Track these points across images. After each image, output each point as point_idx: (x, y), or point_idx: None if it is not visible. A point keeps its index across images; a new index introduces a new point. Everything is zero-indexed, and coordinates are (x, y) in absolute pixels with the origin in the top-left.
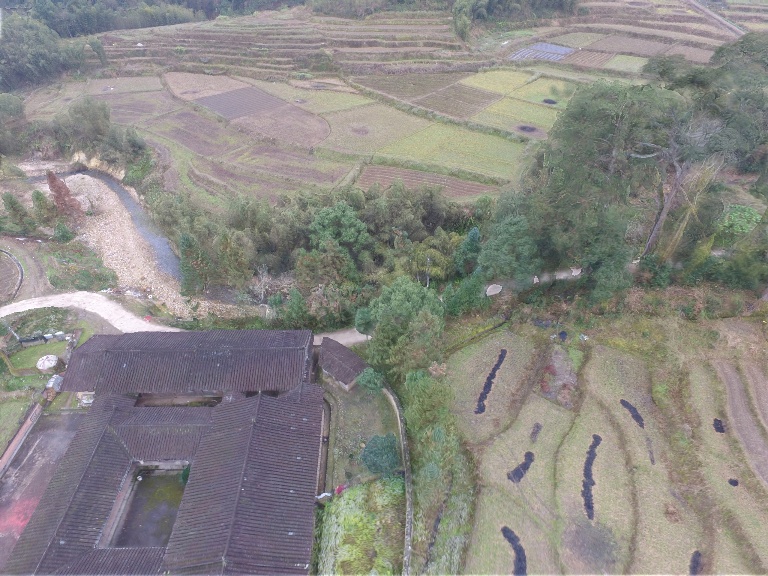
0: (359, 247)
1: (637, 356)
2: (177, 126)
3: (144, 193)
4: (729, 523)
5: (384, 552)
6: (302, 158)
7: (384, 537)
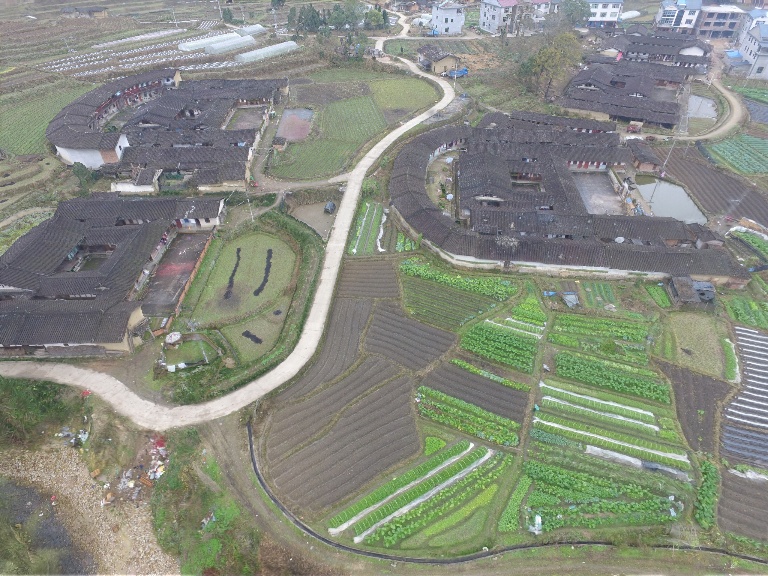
0: None
1: None
2: None
3: None
4: None
5: None
6: None
7: None
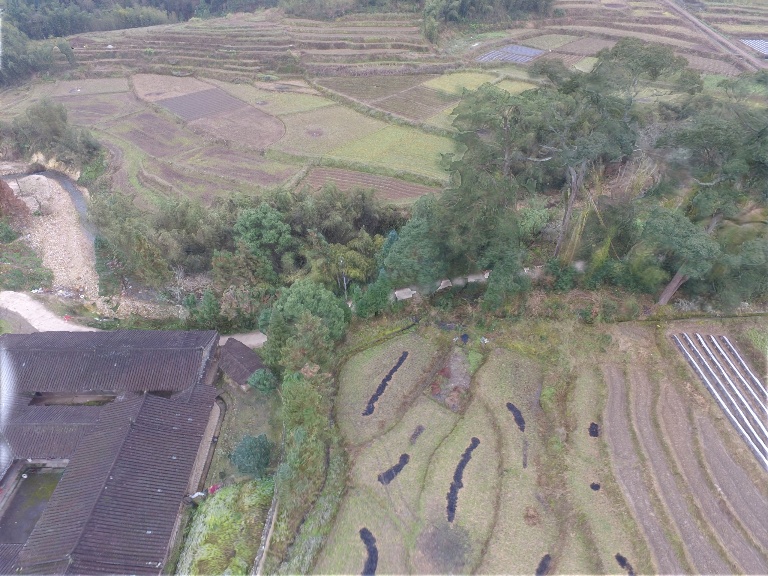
0: (281, 249)
1: (534, 359)
2: (135, 127)
3: None
4: (582, 527)
5: (242, 552)
6: (252, 160)
7: (246, 537)
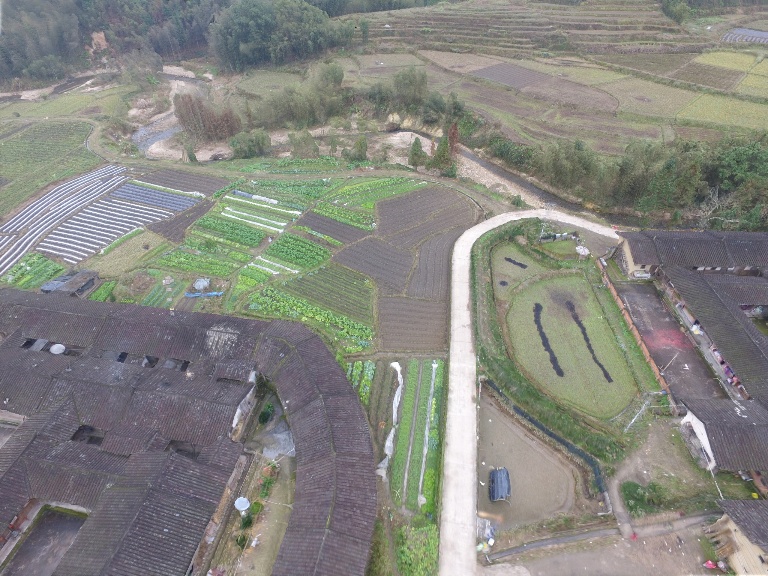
0: None
1: None
2: (473, 93)
3: (479, 146)
4: None
5: None
6: (610, 120)
7: None
